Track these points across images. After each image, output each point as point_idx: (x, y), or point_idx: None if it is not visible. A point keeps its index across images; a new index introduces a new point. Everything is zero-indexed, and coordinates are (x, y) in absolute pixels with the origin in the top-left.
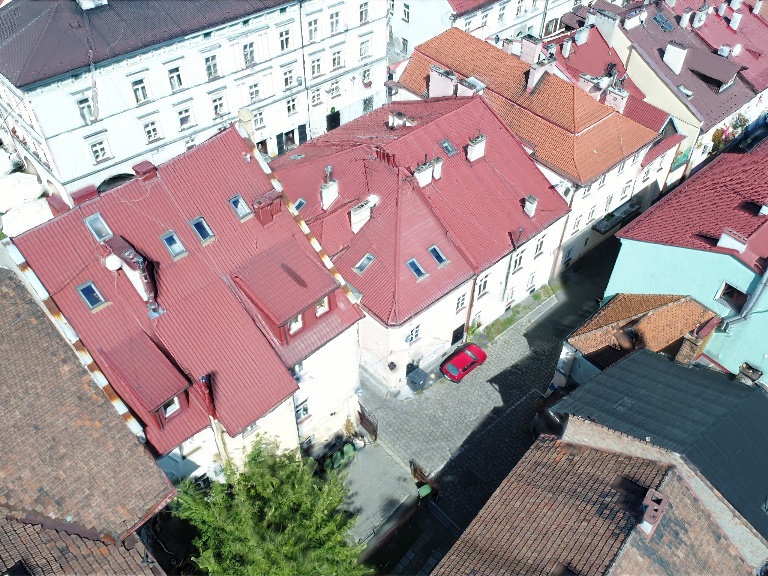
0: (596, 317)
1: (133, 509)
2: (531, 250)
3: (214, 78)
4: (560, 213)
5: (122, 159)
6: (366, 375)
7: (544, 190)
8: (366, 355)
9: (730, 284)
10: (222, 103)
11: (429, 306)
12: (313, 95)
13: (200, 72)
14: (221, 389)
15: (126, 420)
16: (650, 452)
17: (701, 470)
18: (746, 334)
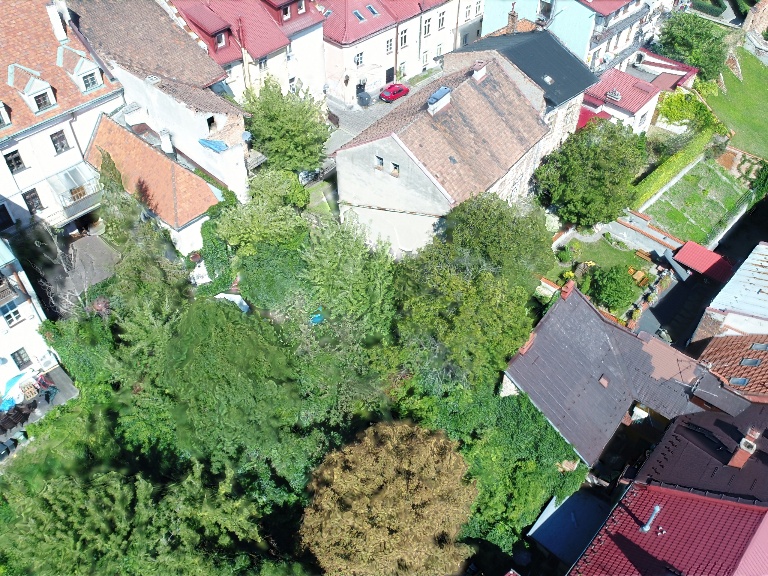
0: None
1: (206, 78)
2: (435, 20)
3: None
4: None
5: None
6: (331, 101)
7: None
8: (330, 83)
9: None
10: None
11: (368, 36)
12: None
13: None
14: (247, 37)
15: (198, 41)
16: (483, 56)
17: (509, 59)
18: (555, 32)
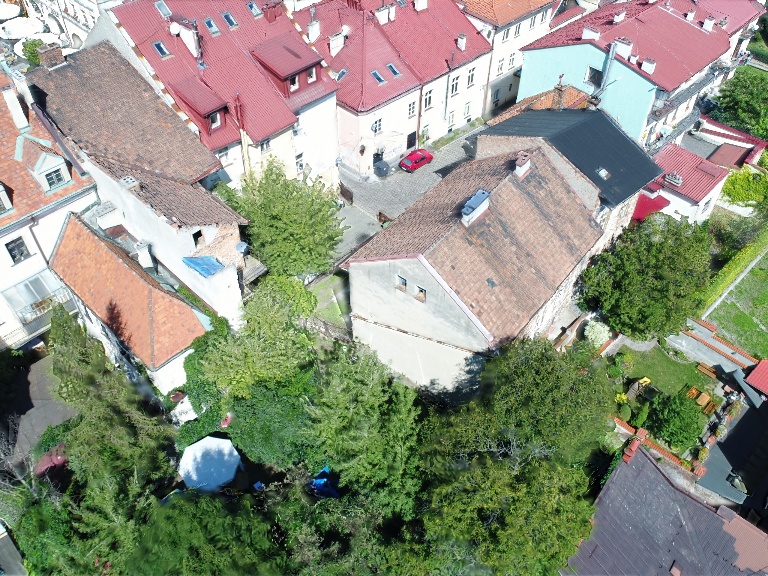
0: (507, 110)
1: (196, 170)
2: (464, 78)
3: None
4: (485, 50)
5: None
6: (344, 169)
7: (473, 35)
8: (344, 150)
9: (592, 67)
10: None
11: (387, 101)
12: None
13: None
14: (247, 115)
15: (188, 123)
16: (526, 143)
17: (557, 148)
18: (605, 104)
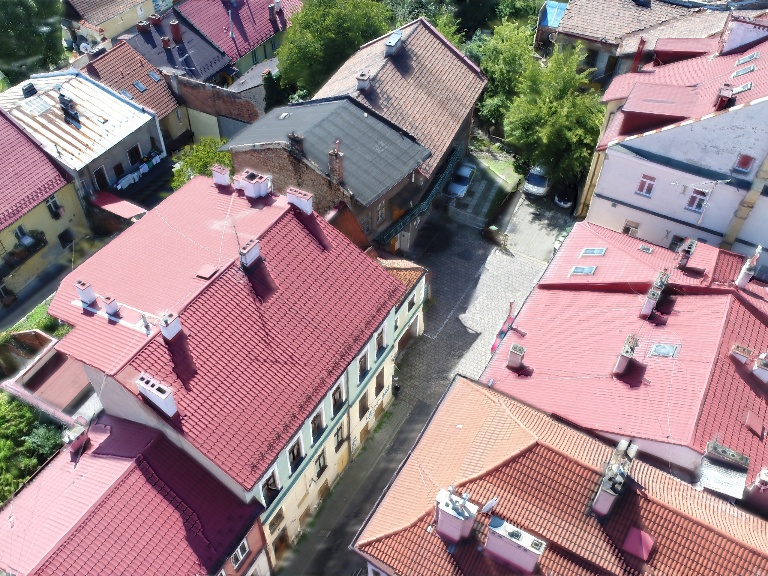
0: None
1: None
2: None
3: None
4: None
5: None
6: None
7: None
8: None
9: None
10: None
11: None
12: None
13: None
14: None
15: None
16: None
17: None
18: None
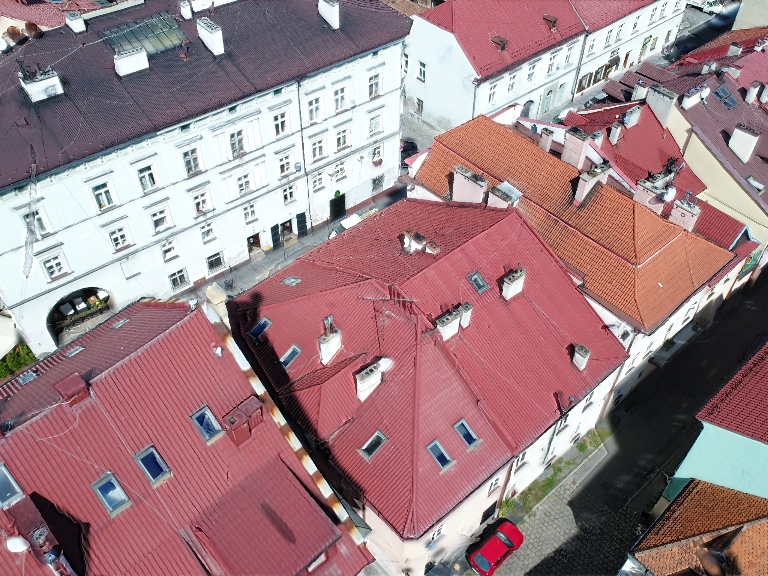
0: (669, 518)
1: None
2: (580, 407)
3: (195, 173)
4: (616, 361)
5: (83, 272)
6: (374, 565)
7: (596, 331)
8: (374, 547)
9: None
10: (205, 199)
11: (456, 507)
12: (314, 180)
13: (177, 169)
14: None
15: None
16: None
17: None
18: None
